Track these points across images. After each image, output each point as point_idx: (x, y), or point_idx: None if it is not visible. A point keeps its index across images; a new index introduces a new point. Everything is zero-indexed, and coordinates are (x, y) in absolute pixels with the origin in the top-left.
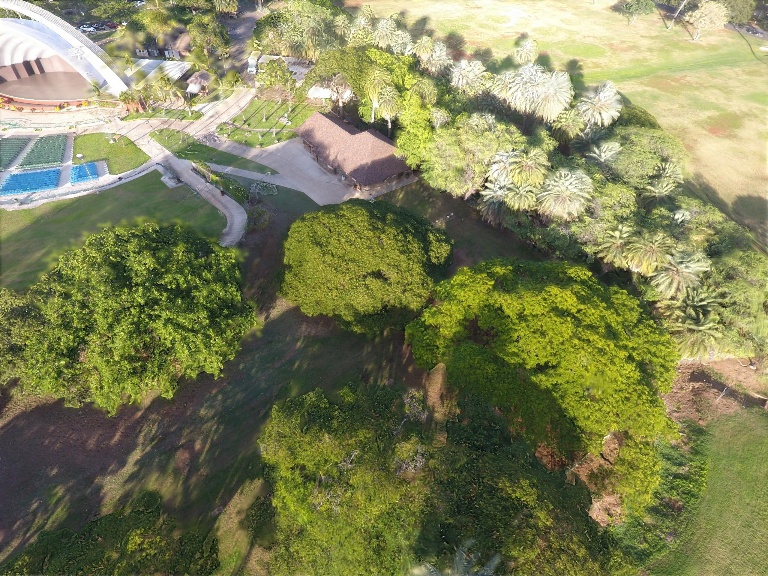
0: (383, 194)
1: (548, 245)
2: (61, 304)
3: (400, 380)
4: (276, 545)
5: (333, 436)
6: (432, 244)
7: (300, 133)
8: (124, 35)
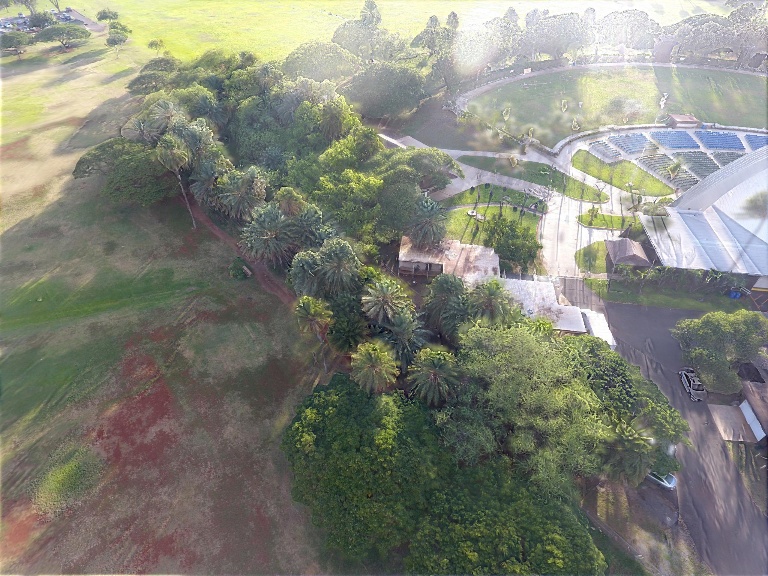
0: None
1: None
2: None
3: None
4: None
5: None
6: None
7: None
8: None
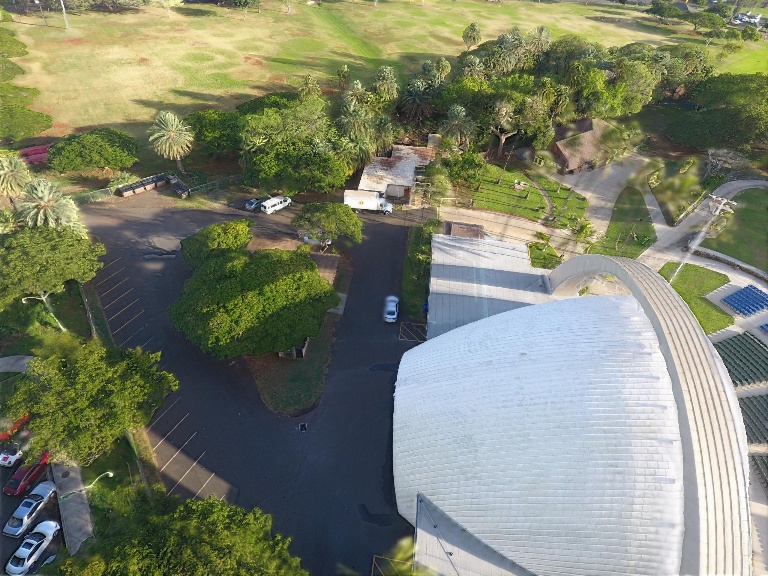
0: None
1: None
2: None
3: None
4: None
5: None
6: None
7: (577, 163)
8: (288, 348)
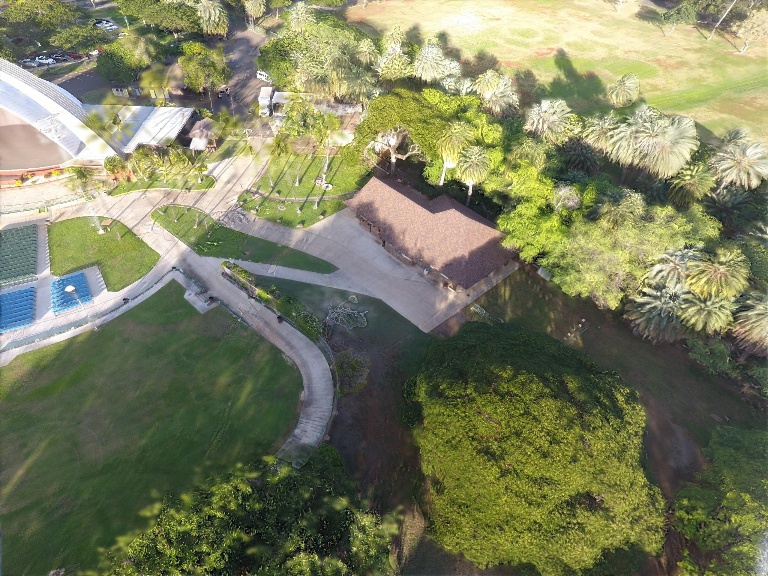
0: (484, 293)
1: (741, 374)
2: None
3: None
4: None
5: None
6: (624, 411)
7: (356, 208)
8: (96, 71)
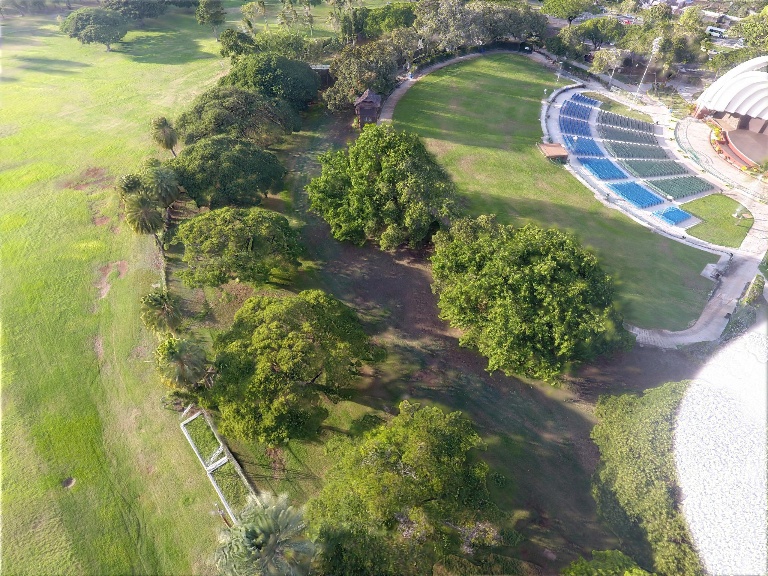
0: None
1: None
2: (486, 240)
3: (558, 569)
4: (350, 439)
5: (433, 459)
6: None
7: None
8: None
